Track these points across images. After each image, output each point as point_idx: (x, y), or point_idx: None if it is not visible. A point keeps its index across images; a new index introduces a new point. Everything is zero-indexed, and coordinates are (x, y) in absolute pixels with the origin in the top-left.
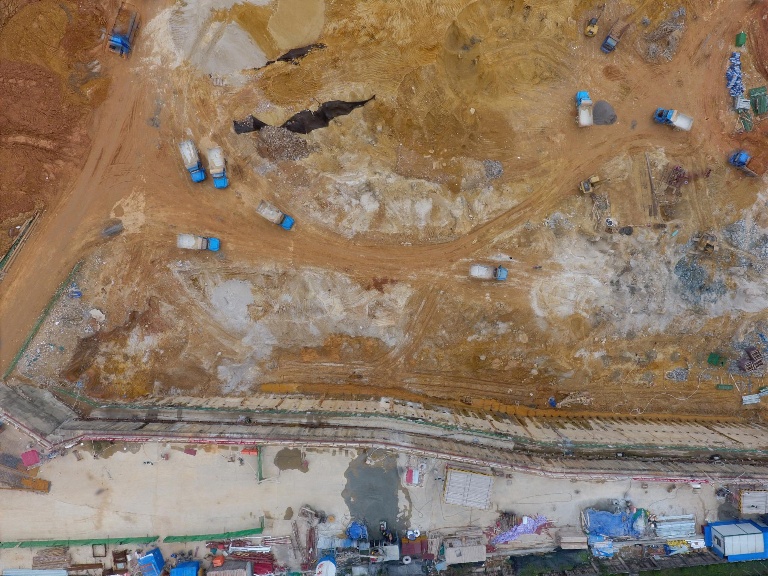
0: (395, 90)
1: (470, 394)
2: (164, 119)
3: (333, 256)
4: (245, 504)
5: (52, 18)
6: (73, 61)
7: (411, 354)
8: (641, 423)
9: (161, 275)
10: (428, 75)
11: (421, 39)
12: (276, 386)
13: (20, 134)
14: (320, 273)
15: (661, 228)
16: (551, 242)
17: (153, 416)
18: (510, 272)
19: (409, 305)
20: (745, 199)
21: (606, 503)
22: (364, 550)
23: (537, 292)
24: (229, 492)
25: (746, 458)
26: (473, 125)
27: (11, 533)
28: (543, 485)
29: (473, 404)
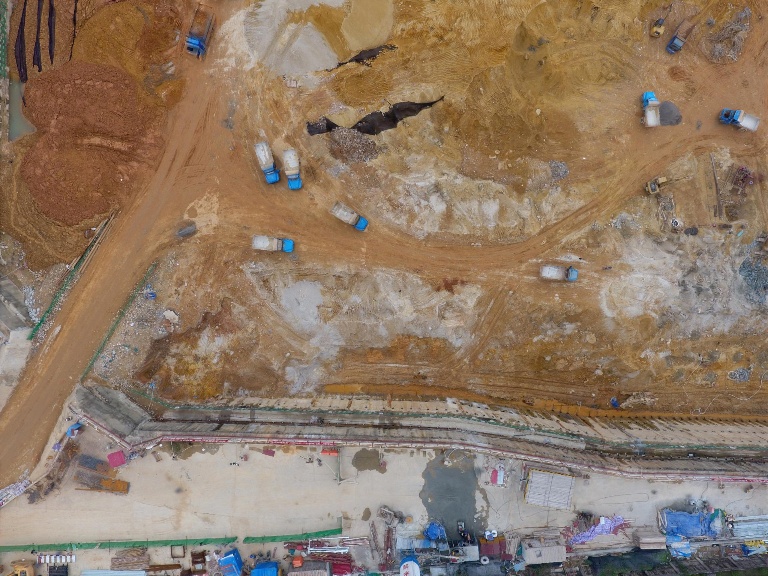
0: (464, 91)
1: (532, 394)
2: (238, 120)
3: (404, 257)
4: (323, 505)
5: (129, 20)
6: (148, 63)
7: (476, 355)
8: (705, 423)
9: (234, 276)
10: (496, 76)
11: (490, 40)
12: (340, 387)
13: (95, 136)
14: (392, 274)
15: (726, 228)
16: (619, 243)
17: (226, 417)
18: (579, 273)
19: (477, 306)
20: None
21: (683, 503)
22: (444, 551)
23: (606, 293)
24: (307, 493)
25: None
26: (538, 126)
27: (89, 534)
28: (620, 485)
29: (535, 404)
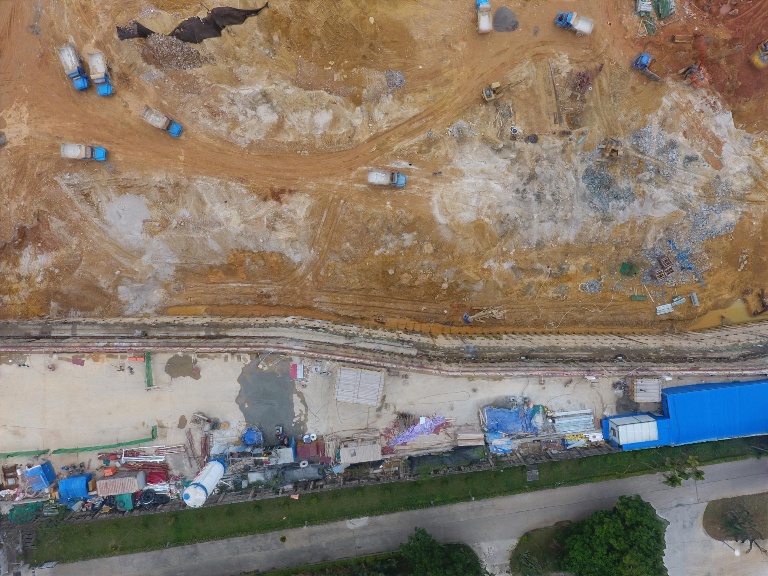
0: None
1: (384, 313)
2: (44, 26)
3: (227, 165)
4: (137, 414)
5: None
6: None
7: (318, 270)
8: (554, 335)
9: (48, 188)
10: None
11: None
12: (183, 309)
13: None
14: (213, 183)
15: (566, 135)
16: (452, 149)
17: (46, 334)
18: (410, 179)
19: (310, 217)
20: (650, 104)
21: (504, 401)
22: (257, 453)
23: (438, 199)
24: (120, 402)
25: (650, 357)
26: (373, 35)
27: None
28: (440, 384)
29: (387, 323)
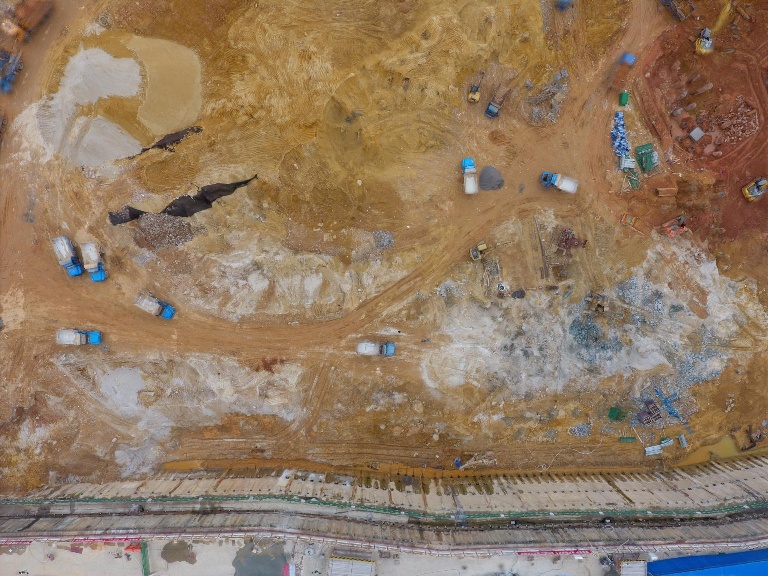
0: (276, 169)
1: (376, 459)
2: (38, 214)
3: (219, 341)
4: None
5: None
6: None
7: (311, 427)
8: (544, 481)
9: (45, 370)
10: (309, 151)
11: (300, 116)
12: (180, 464)
13: None
14: (206, 359)
15: (553, 290)
16: (441, 312)
17: (46, 510)
18: (399, 346)
19: (302, 382)
20: (635, 257)
21: None
22: None
23: (427, 364)
24: None
25: (637, 519)
26: (361, 196)
27: None
28: (430, 563)
29: (380, 469)
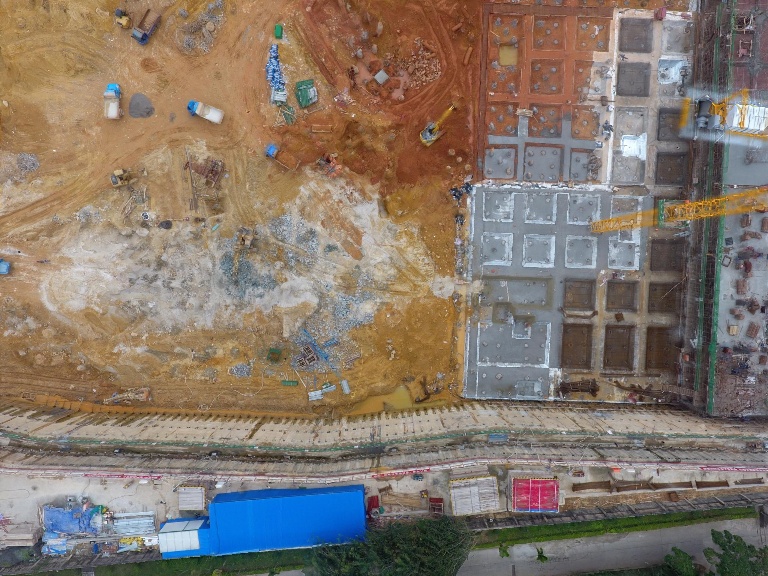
0: None
1: (32, 390)
2: None
3: None
4: None
5: None
6: None
7: None
8: (195, 419)
9: None
10: None
11: None
12: None
13: None
14: None
15: (201, 222)
16: (70, 236)
17: None
18: (19, 266)
19: None
20: (287, 193)
21: (64, 500)
22: None
23: (46, 286)
24: None
25: (246, 454)
26: (8, 118)
27: None
28: None
29: (35, 400)
